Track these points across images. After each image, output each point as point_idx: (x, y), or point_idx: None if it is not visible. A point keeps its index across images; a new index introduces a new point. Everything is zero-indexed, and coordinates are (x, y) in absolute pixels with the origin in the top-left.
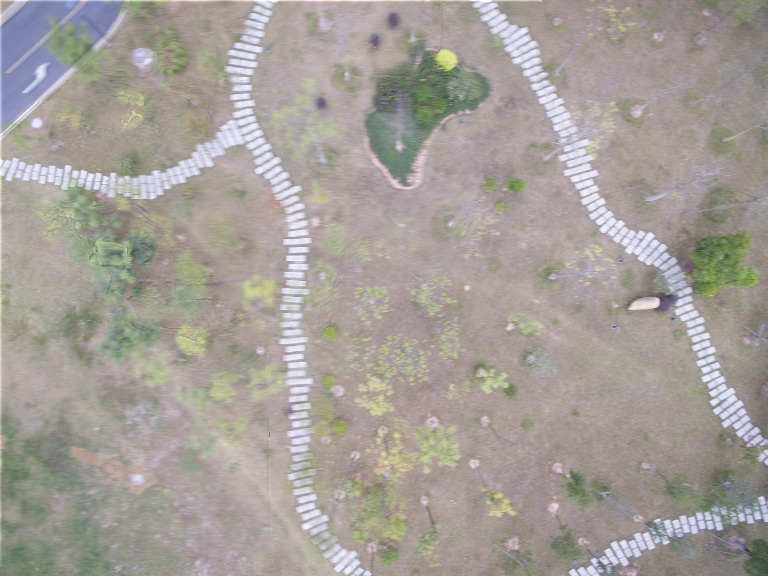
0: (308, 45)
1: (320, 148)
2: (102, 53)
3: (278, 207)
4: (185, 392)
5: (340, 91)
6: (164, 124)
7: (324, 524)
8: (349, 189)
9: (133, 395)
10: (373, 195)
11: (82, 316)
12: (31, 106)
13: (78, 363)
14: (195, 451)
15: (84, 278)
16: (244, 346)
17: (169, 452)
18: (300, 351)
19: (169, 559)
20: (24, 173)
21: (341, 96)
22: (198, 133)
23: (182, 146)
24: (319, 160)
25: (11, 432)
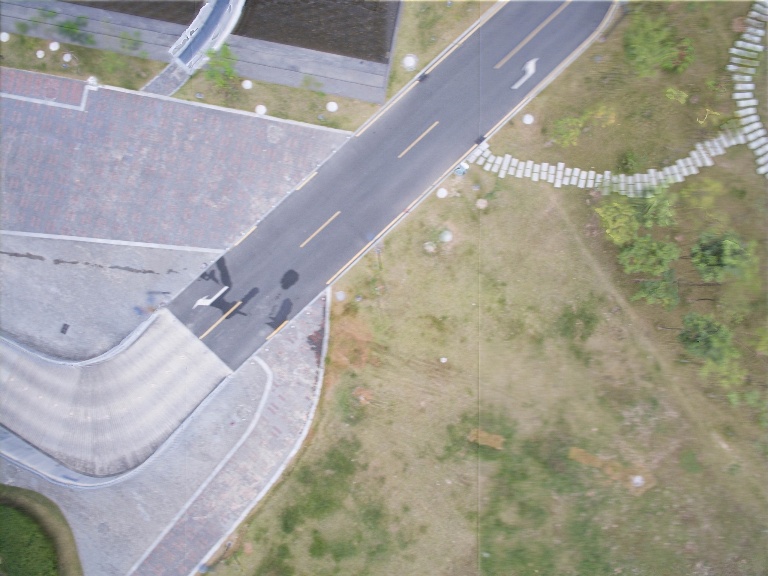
0: None
1: None
2: (593, 49)
3: None
4: (684, 393)
5: None
6: (662, 122)
7: None
8: None
9: (632, 396)
10: None
11: (579, 315)
12: (520, 102)
13: (577, 363)
14: (695, 452)
15: (580, 277)
16: None
17: (668, 453)
18: None
19: (670, 561)
20: (517, 170)
21: None
22: (699, 132)
23: (680, 145)
24: None
25: (509, 432)
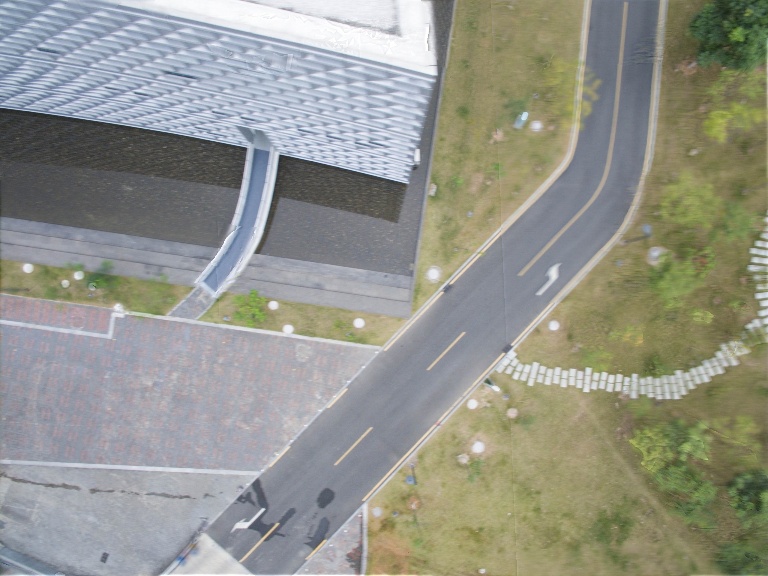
0: None
1: None
2: (615, 252)
3: None
4: None
5: None
6: (686, 324)
7: None
8: None
9: None
10: None
11: (614, 520)
12: (546, 308)
13: (614, 567)
14: None
15: (613, 481)
16: None
17: None
18: None
19: None
20: (545, 377)
21: None
22: (724, 333)
23: (705, 345)
24: None
25: None
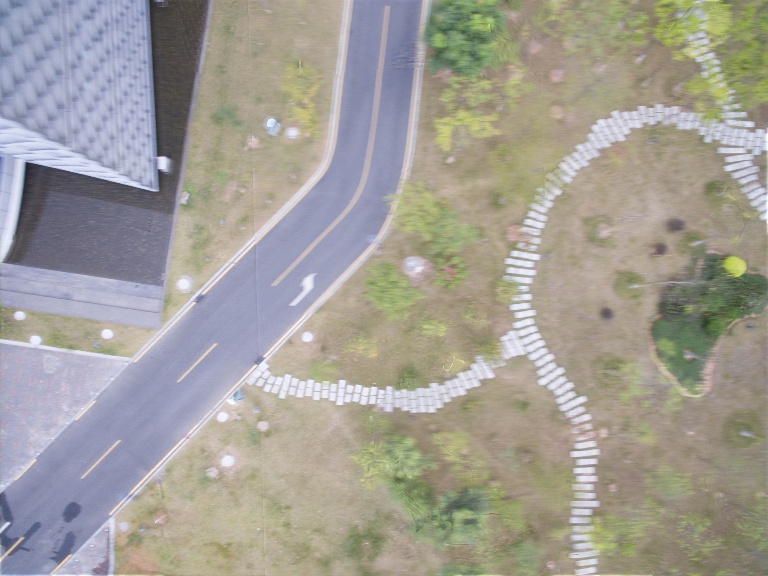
0: (587, 251)
1: (606, 358)
2: (371, 262)
3: (563, 418)
4: None
5: (624, 299)
6: (441, 336)
7: None
8: (636, 398)
9: None
10: (661, 404)
11: (365, 535)
12: (300, 319)
13: None
14: None
15: (365, 496)
16: (534, 560)
17: None
18: (593, 565)
19: None
20: (297, 390)
21: (625, 304)
22: (478, 345)
23: (460, 358)
24: (606, 371)
25: None
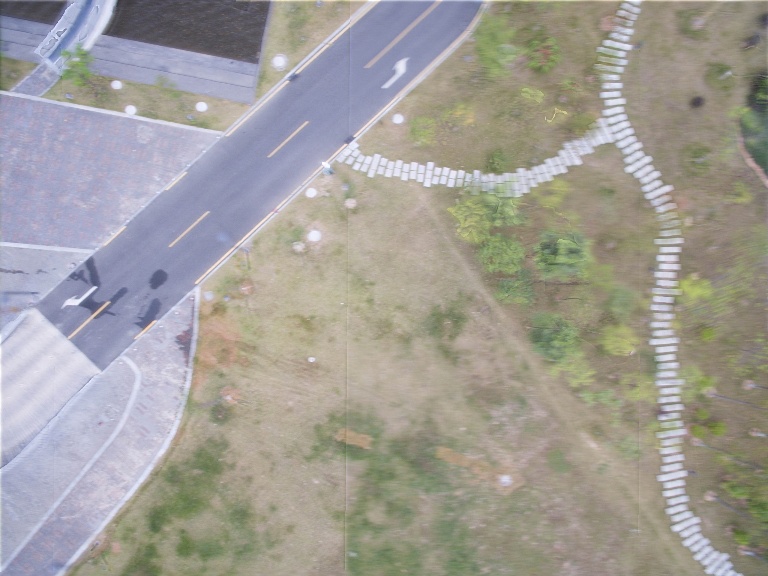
0: (678, 43)
1: (694, 147)
2: (463, 49)
3: (648, 206)
4: (553, 392)
5: (714, 90)
6: (530, 121)
7: (695, 526)
8: (722, 189)
9: (500, 395)
10: (747, 195)
11: (448, 315)
12: (391, 102)
13: (445, 362)
14: (563, 452)
15: (449, 276)
16: None
17: (537, 453)
18: (673, 352)
19: (538, 561)
20: (386, 169)
21: (714, 95)
22: (567, 131)
23: (549, 144)
24: (693, 159)
25: (376, 432)
